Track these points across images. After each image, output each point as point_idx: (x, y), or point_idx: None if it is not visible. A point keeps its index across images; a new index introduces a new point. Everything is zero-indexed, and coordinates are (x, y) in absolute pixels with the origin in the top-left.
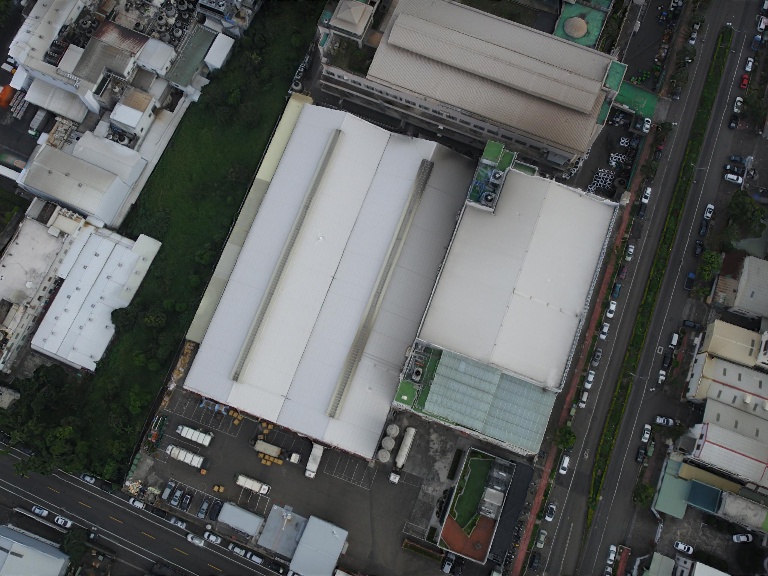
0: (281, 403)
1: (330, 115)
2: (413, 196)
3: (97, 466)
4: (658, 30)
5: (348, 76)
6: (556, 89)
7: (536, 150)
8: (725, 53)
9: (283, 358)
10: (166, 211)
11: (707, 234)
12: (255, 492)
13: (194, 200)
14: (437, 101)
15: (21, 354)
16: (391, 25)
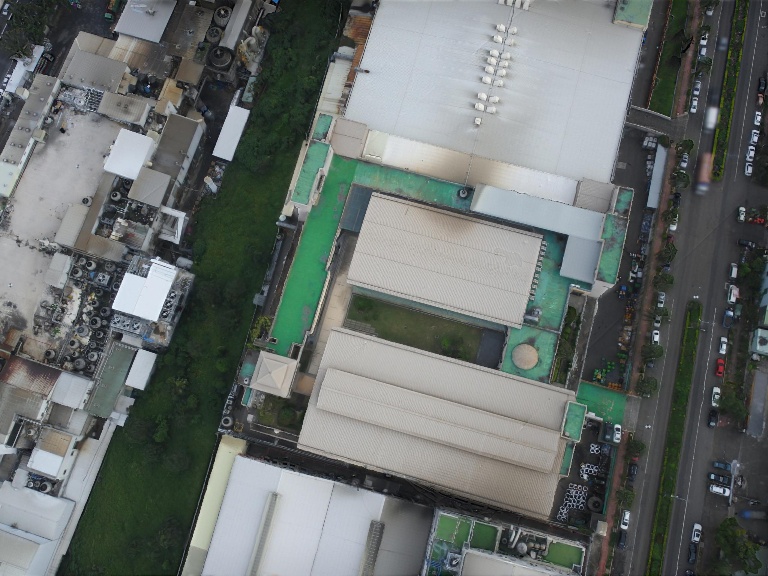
0: None
1: (264, 472)
2: (365, 569)
3: None
4: (618, 307)
5: (279, 430)
6: (510, 449)
7: (495, 510)
8: (695, 335)
9: None
10: (99, 572)
11: (697, 560)
12: None
13: (128, 557)
14: (379, 468)
15: None
16: (319, 381)
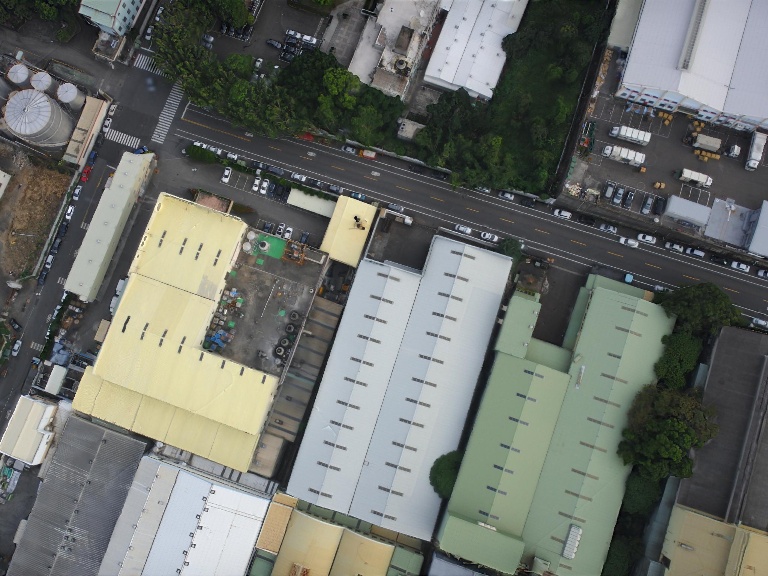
0: (725, 93)
1: None
2: None
3: (520, 180)
4: None
5: None
6: None
7: None
8: None
9: (722, 48)
10: None
11: None
12: (700, 184)
13: None
14: None
15: (411, 89)
16: None
